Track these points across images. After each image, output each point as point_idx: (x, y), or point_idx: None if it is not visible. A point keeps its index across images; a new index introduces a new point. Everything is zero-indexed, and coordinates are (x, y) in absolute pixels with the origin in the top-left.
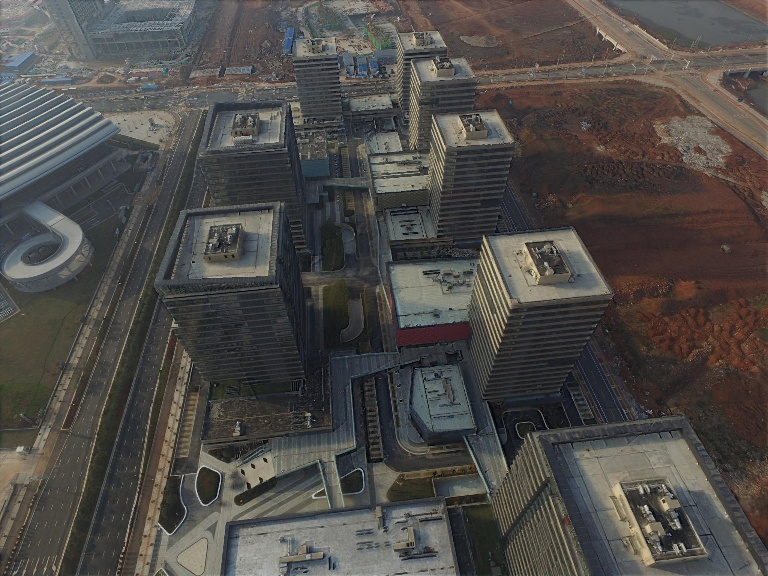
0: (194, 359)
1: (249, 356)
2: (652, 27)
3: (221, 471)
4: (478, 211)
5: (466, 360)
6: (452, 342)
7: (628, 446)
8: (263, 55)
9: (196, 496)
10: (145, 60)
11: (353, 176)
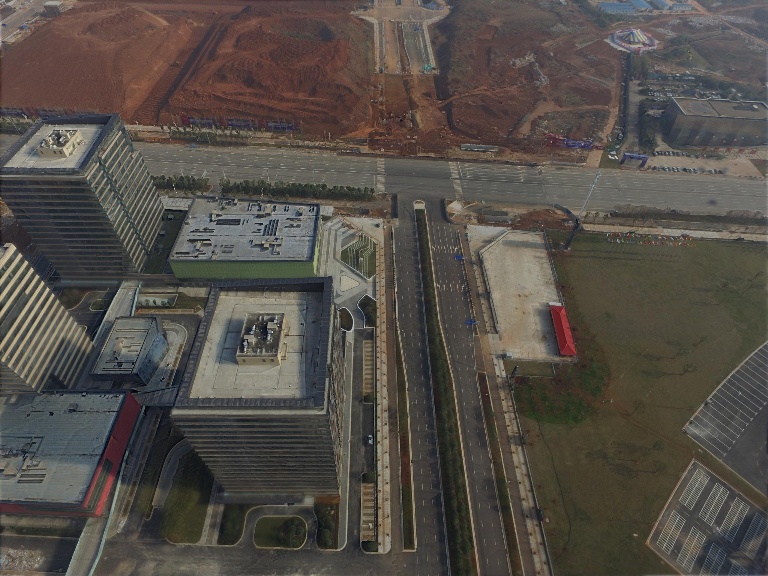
0: None
1: None
2: None
3: None
4: None
5: None
6: None
7: None
8: None
9: (352, 314)
10: None
11: None
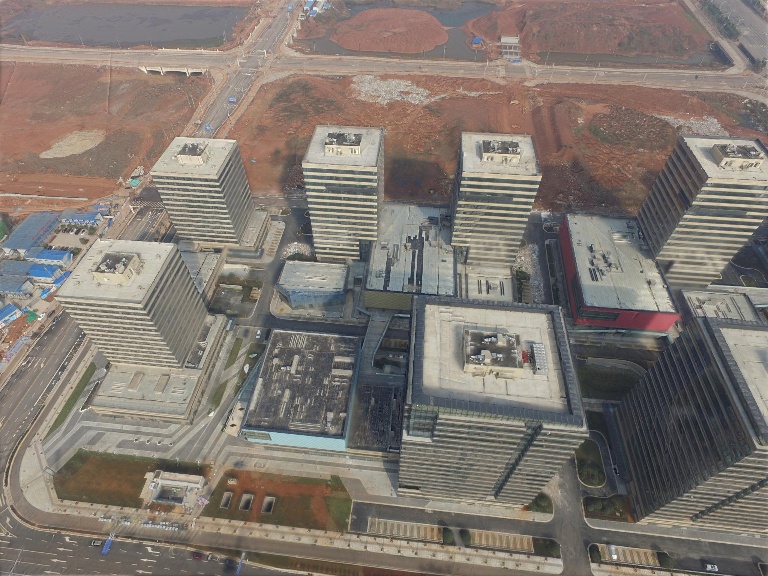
0: None
1: None
2: (164, 45)
3: None
4: None
5: None
6: None
7: None
8: None
9: None
10: None
11: (348, 332)
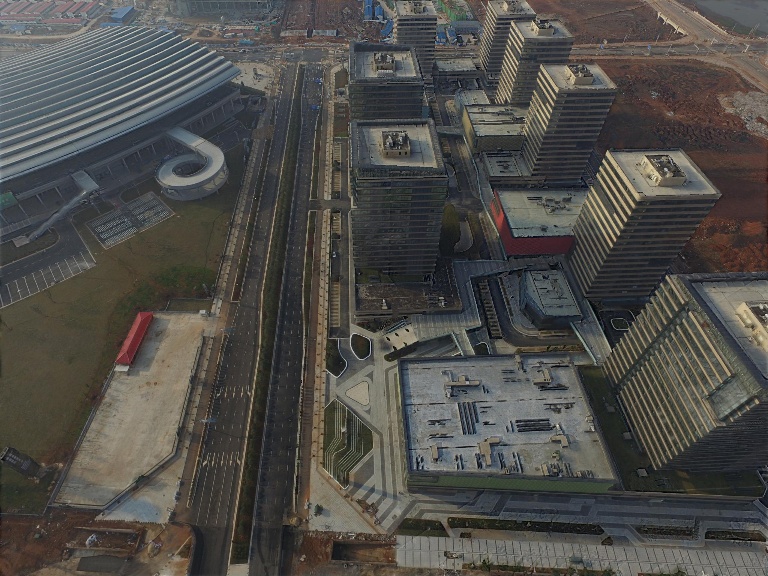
0: (355, 243)
1: (399, 244)
2: (710, 15)
3: (369, 338)
4: (572, 152)
5: (566, 270)
6: (552, 256)
7: (745, 287)
8: (346, 20)
9: (353, 353)
10: (237, 19)
11: None
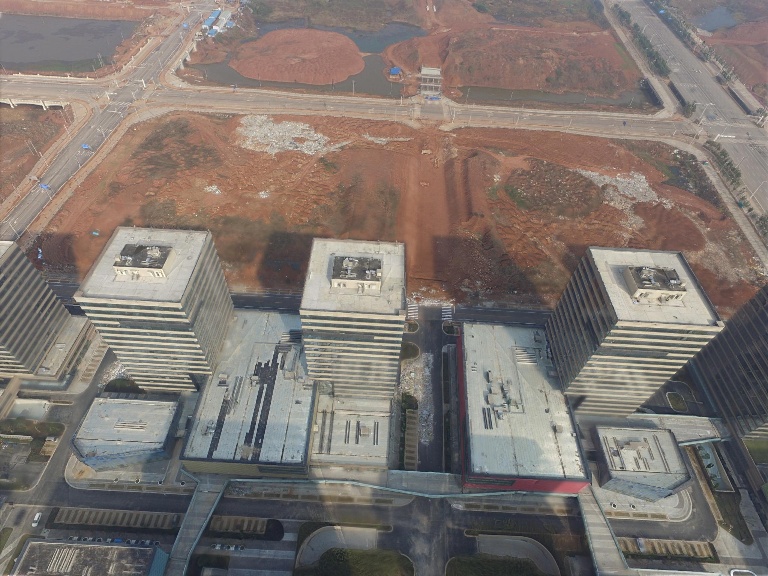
0: None
1: None
2: (25, 68)
3: None
4: None
5: (577, 419)
6: None
7: None
8: None
9: None
10: None
11: (166, 508)
